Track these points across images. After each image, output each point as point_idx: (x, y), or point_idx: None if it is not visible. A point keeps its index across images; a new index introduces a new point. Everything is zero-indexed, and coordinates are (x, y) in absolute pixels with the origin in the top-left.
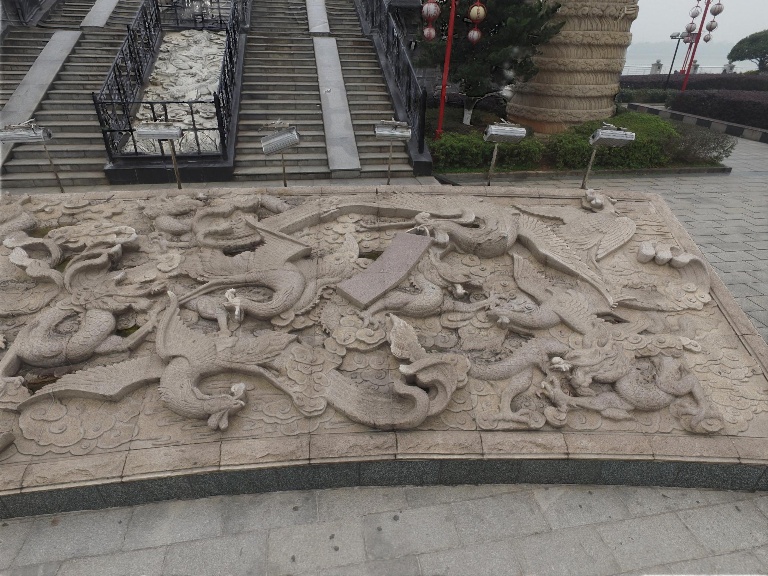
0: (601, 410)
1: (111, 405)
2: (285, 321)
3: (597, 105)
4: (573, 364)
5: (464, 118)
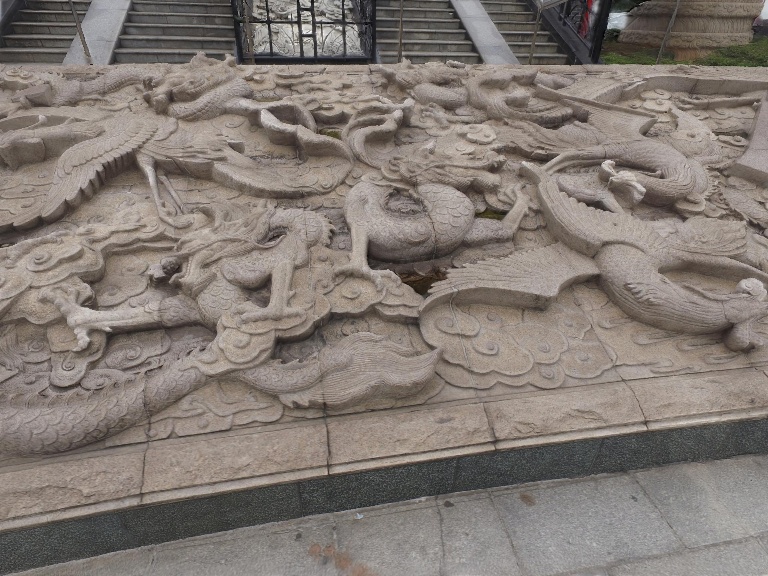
0: None
1: (537, 314)
2: (698, 205)
3: (739, 28)
4: None
5: None
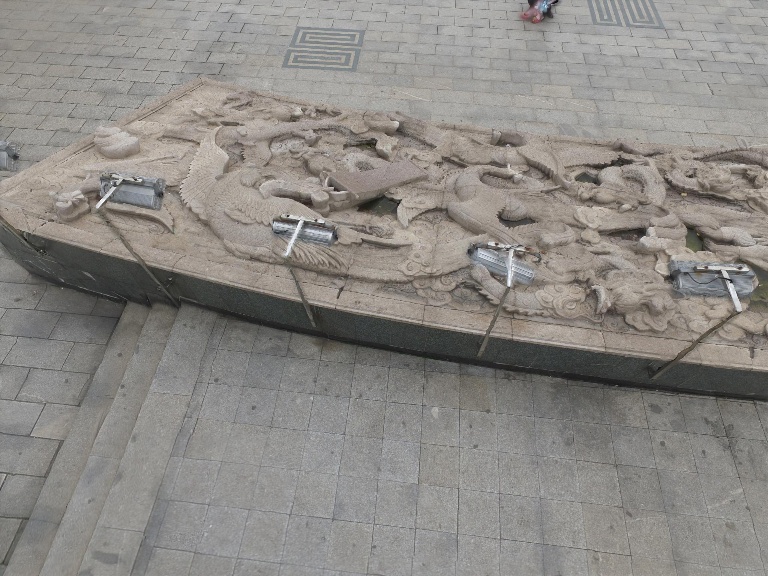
0: None
1: None
2: None
3: None
4: None
5: None
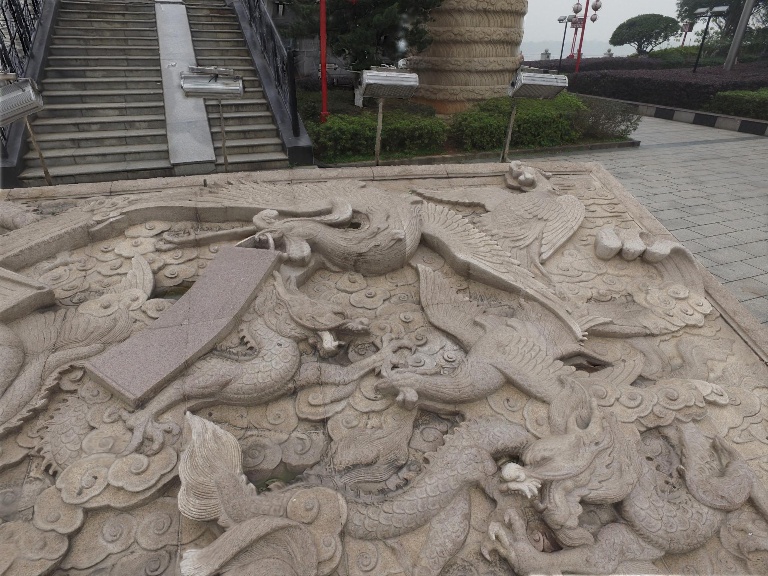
0: (609, 574)
1: None
2: None
3: (499, 80)
4: (543, 478)
5: (355, 99)
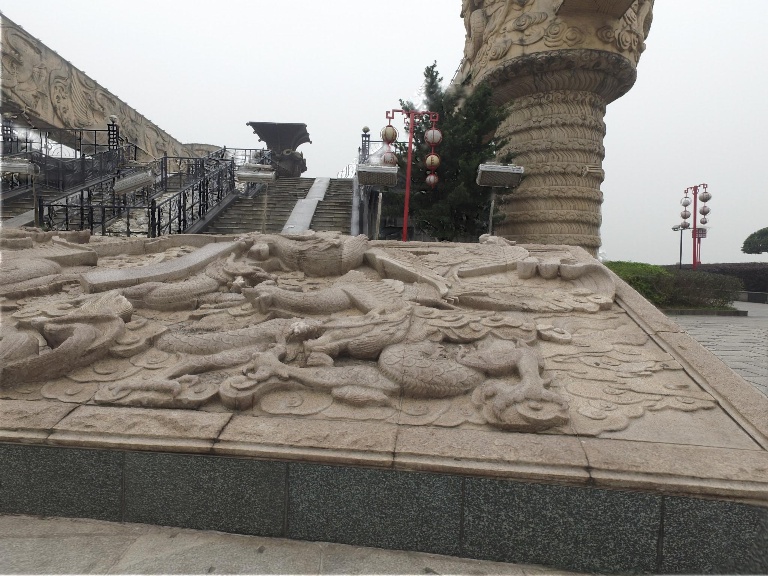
0: (332, 385)
1: None
2: None
3: None
4: (317, 325)
5: None
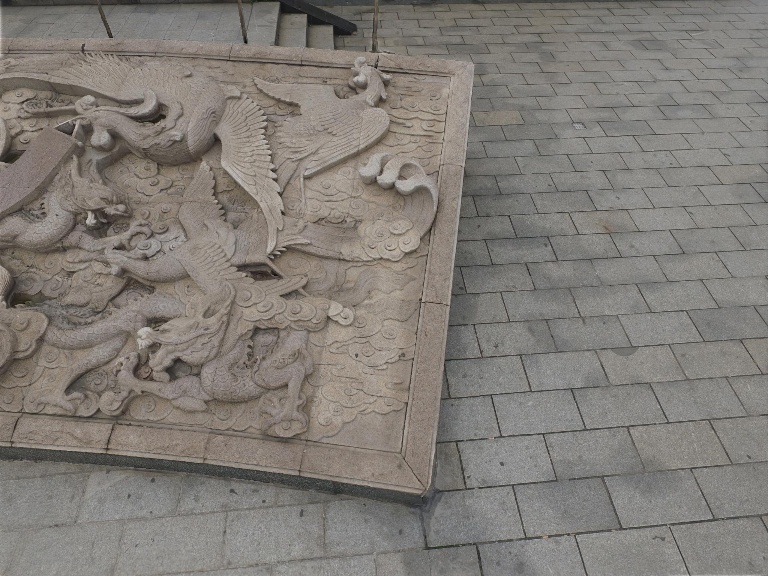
0: (170, 399)
1: None
2: None
3: None
4: (154, 341)
5: None
